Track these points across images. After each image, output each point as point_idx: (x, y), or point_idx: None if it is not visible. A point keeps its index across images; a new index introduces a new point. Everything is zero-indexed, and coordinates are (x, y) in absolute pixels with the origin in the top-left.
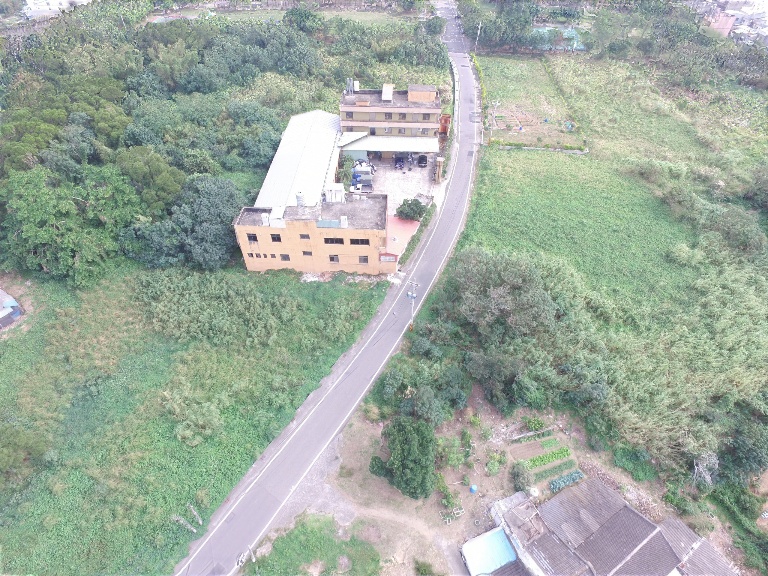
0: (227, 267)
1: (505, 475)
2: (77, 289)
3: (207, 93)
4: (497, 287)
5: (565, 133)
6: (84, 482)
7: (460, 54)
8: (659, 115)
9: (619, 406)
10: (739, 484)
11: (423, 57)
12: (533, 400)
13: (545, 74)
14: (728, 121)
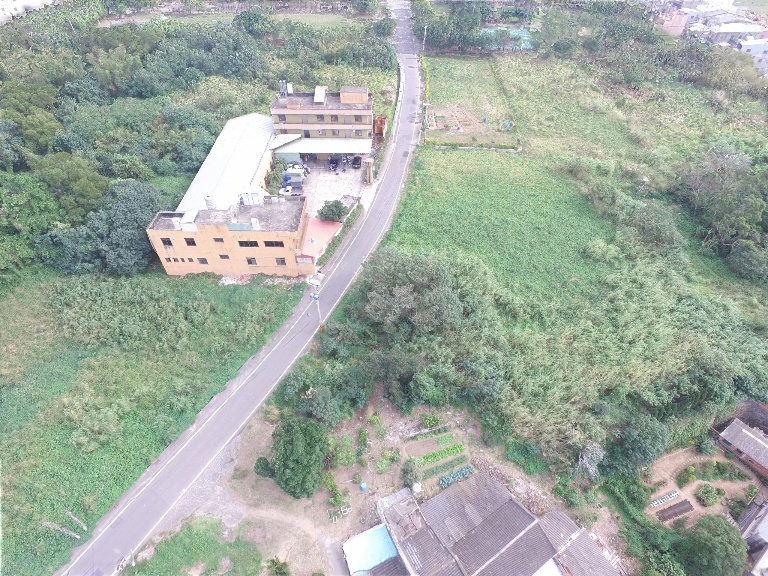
0: (147, 272)
1: (397, 472)
2: None
3: None
4: (403, 286)
5: (502, 132)
6: None
7: (409, 55)
8: (596, 113)
9: (513, 401)
10: (630, 474)
11: (370, 59)
12: (430, 397)
13: (491, 74)
14: (665, 118)
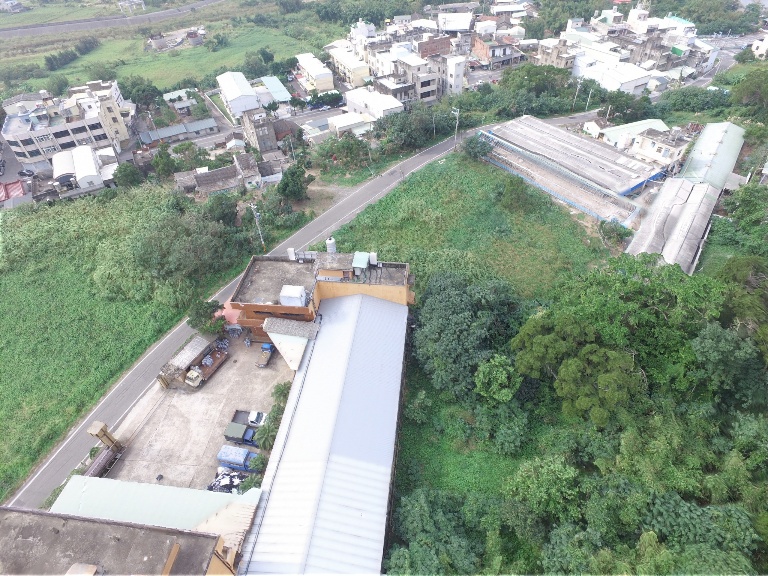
0: None
1: None
2: None
3: None
4: None
5: None
6: None
7: None
8: None
9: None
10: None
11: None
12: None
13: None
14: None
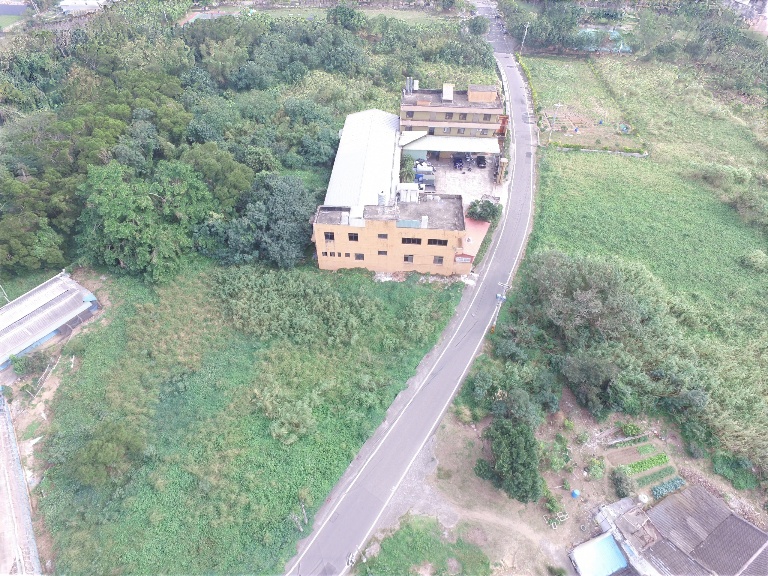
0: (298, 265)
1: (605, 480)
2: (155, 285)
3: None
4: None
5: (621, 135)
6: (184, 478)
7: (505, 54)
8: (715, 119)
9: (717, 413)
10: None
11: (470, 57)
12: (628, 405)
13: (592, 76)
14: None
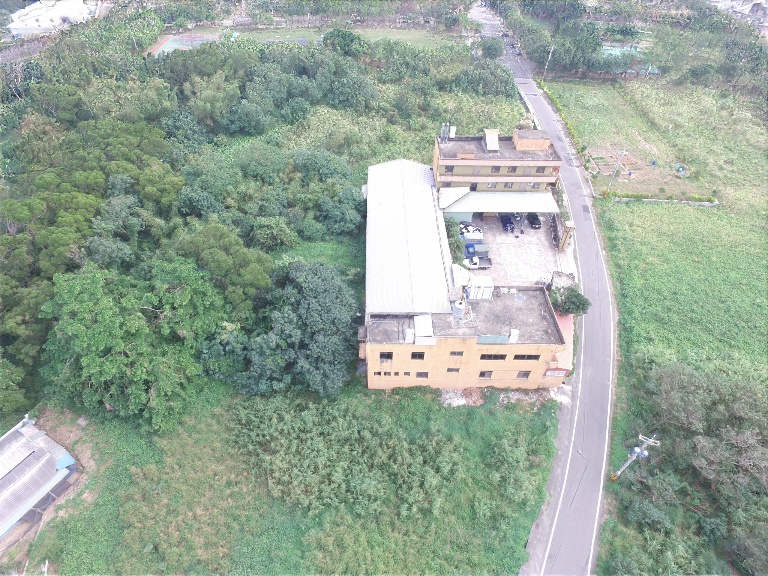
0: None
1: None
2: (155, 435)
3: (253, 134)
4: None
5: (682, 179)
6: None
7: (524, 80)
8: None
9: None
10: None
11: (490, 85)
12: None
13: (625, 103)
14: None
